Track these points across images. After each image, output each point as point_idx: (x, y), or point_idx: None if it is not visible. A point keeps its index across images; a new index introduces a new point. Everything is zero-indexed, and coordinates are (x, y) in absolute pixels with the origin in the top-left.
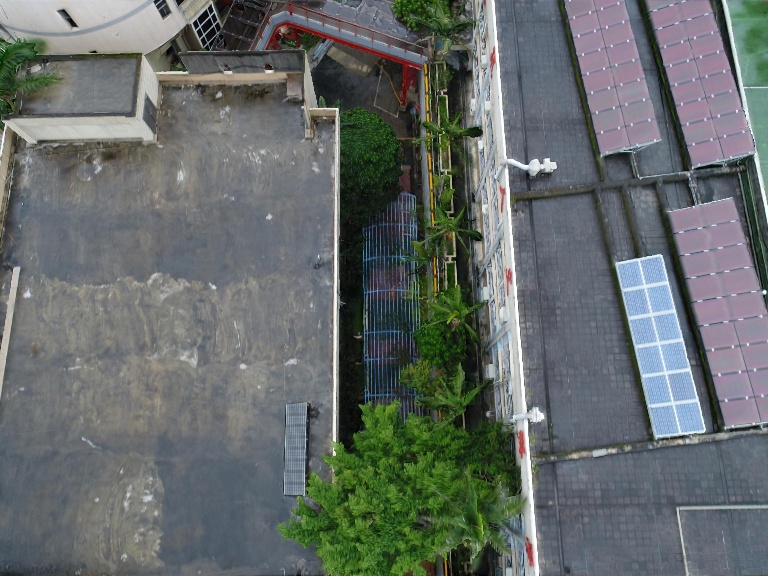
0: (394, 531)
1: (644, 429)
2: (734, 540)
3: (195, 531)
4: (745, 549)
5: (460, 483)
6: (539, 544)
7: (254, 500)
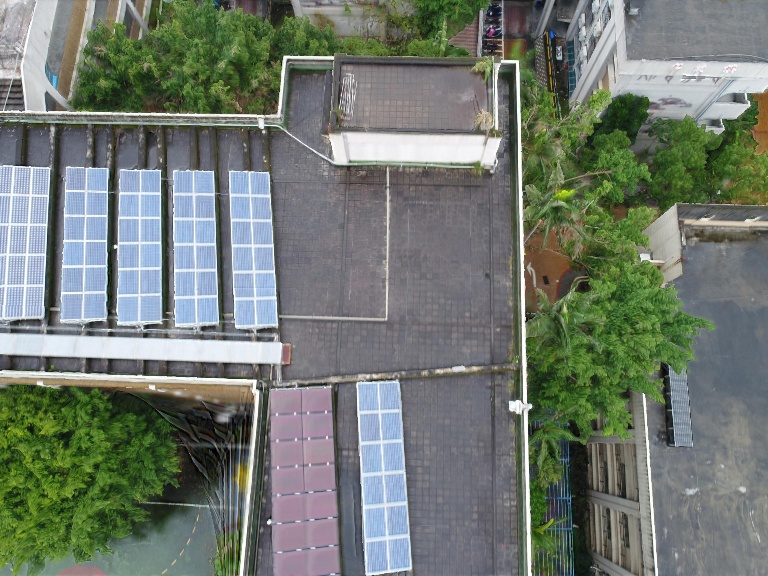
0: (611, 319)
1: (404, 390)
2: (341, 292)
3: (763, 333)
4: (333, 285)
5: (560, 355)
6: (511, 297)
7: (712, 357)
